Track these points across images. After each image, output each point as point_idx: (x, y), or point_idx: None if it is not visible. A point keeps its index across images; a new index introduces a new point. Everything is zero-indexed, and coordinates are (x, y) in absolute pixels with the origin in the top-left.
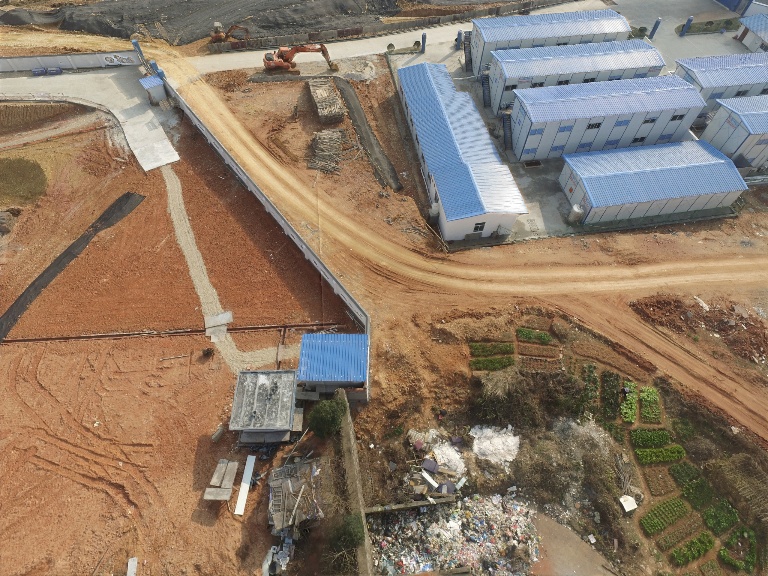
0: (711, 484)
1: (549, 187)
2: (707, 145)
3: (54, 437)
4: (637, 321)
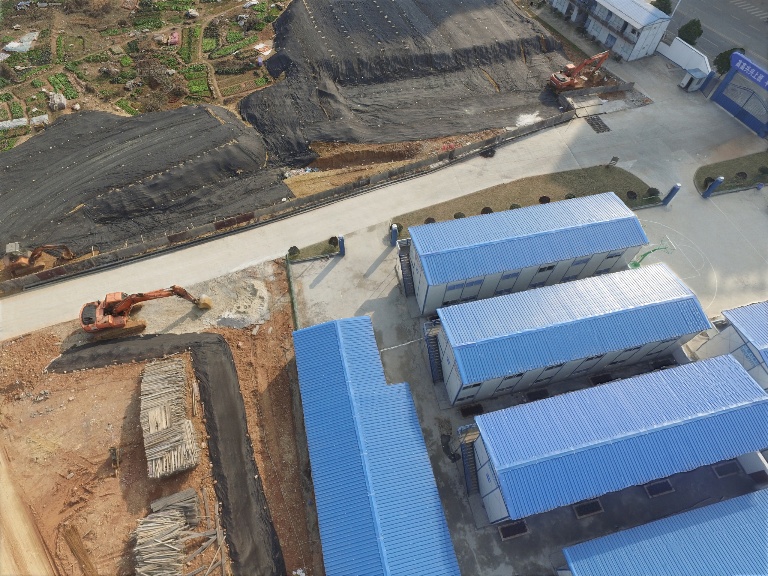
0: None
1: None
2: None
3: None
4: None
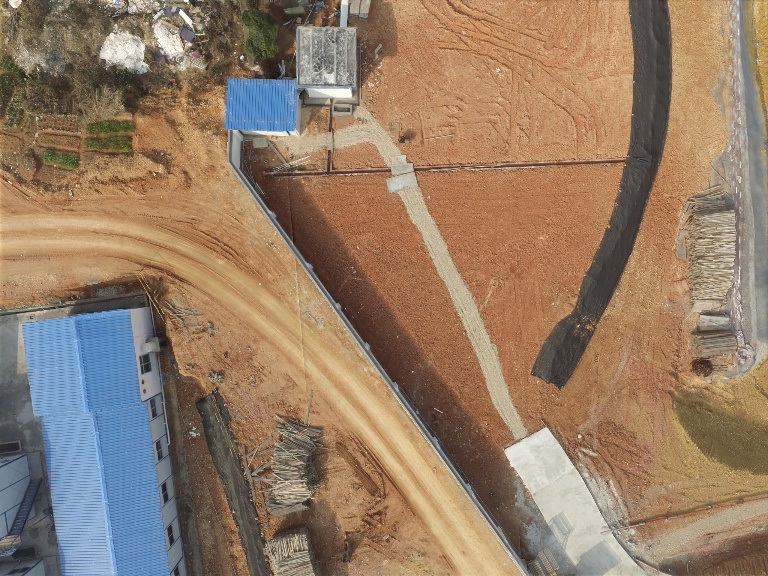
0: None
1: None
2: None
3: (533, 59)
4: None
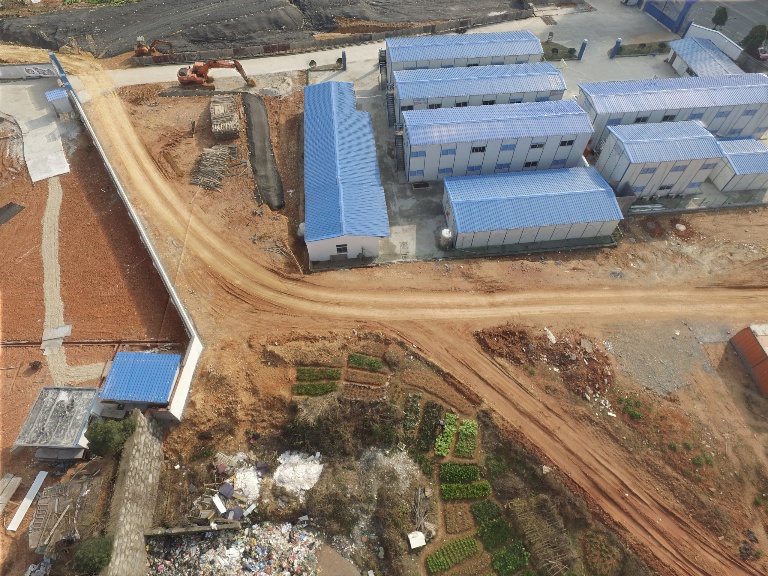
0: (511, 524)
1: (431, 209)
2: (593, 172)
3: None
4: (477, 351)
